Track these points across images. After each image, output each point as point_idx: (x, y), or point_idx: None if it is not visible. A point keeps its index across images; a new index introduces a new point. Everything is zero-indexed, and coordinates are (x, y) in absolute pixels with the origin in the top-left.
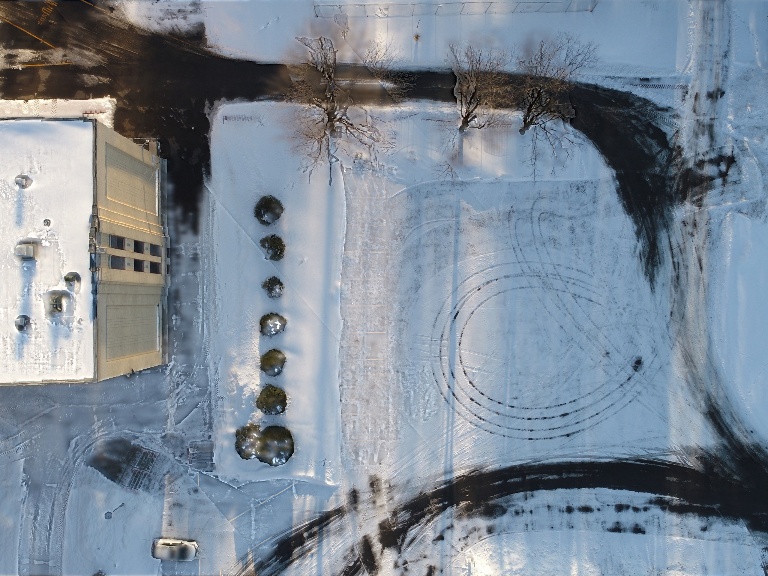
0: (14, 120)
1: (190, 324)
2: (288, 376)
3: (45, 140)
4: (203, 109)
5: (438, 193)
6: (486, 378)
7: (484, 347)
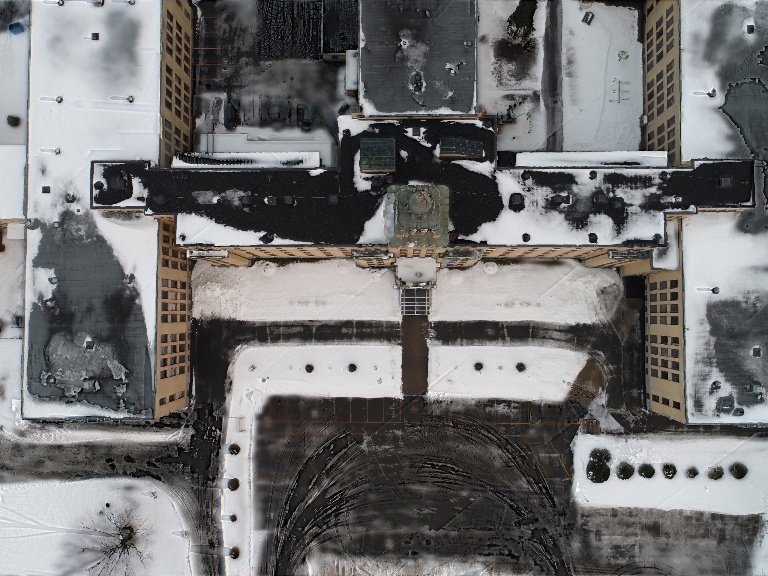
0: None
1: (671, 423)
2: (638, 479)
3: None
4: None
5: (745, 569)
6: None
7: None
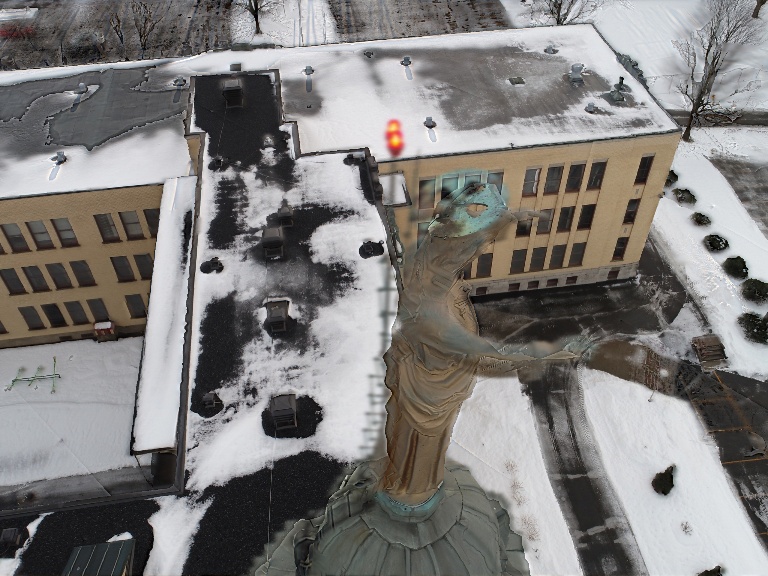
0: (531, 28)
1: None
2: None
3: (558, 34)
4: None
5: None
6: None
7: None
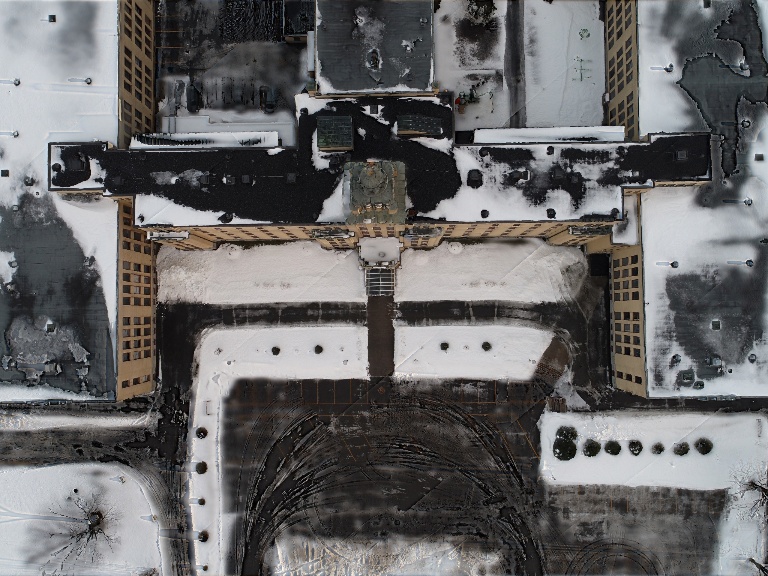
0: None
1: (637, 400)
2: (604, 456)
3: None
4: (765, 407)
5: (712, 544)
6: (599, 570)
7: (618, 569)
